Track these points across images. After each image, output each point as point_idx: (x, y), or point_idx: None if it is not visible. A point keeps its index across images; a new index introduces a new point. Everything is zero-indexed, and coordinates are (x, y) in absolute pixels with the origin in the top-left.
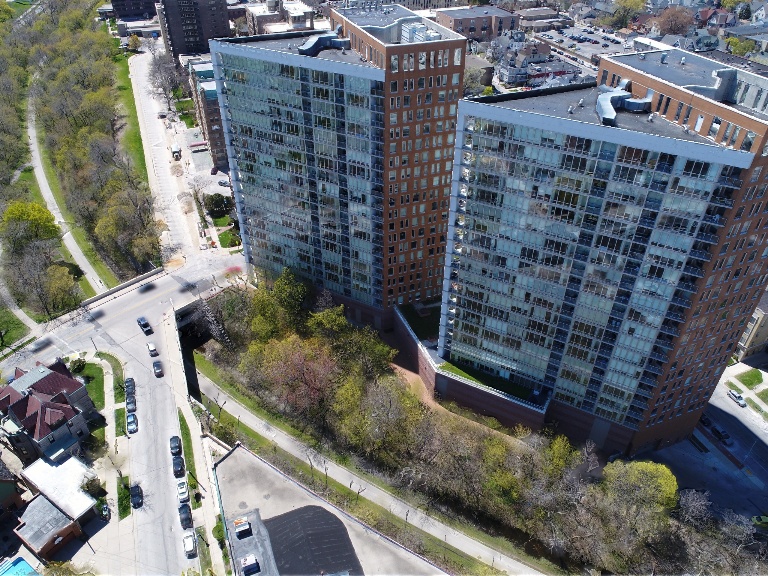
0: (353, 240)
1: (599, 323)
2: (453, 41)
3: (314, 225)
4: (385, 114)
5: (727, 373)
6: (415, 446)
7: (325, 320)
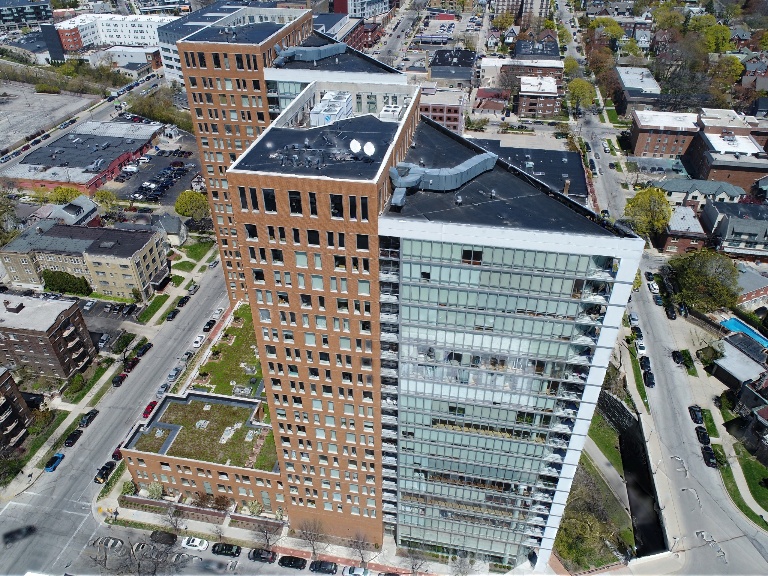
0: None
1: None
2: (332, 83)
3: None
4: None
5: (190, 275)
6: None
7: None
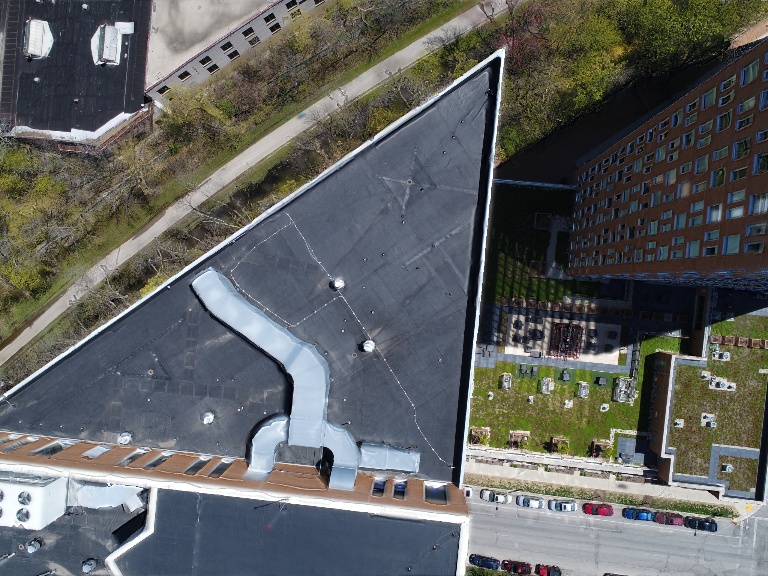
0: None
1: None
2: None
3: None
4: (762, 44)
5: None
6: None
7: None
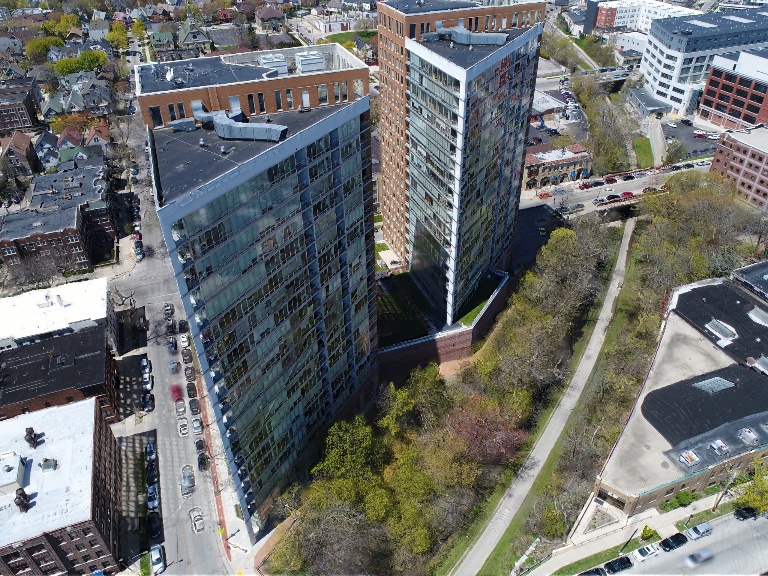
0: (354, 320)
1: None
2: None
3: (320, 351)
4: None
5: None
6: (507, 386)
7: (404, 408)
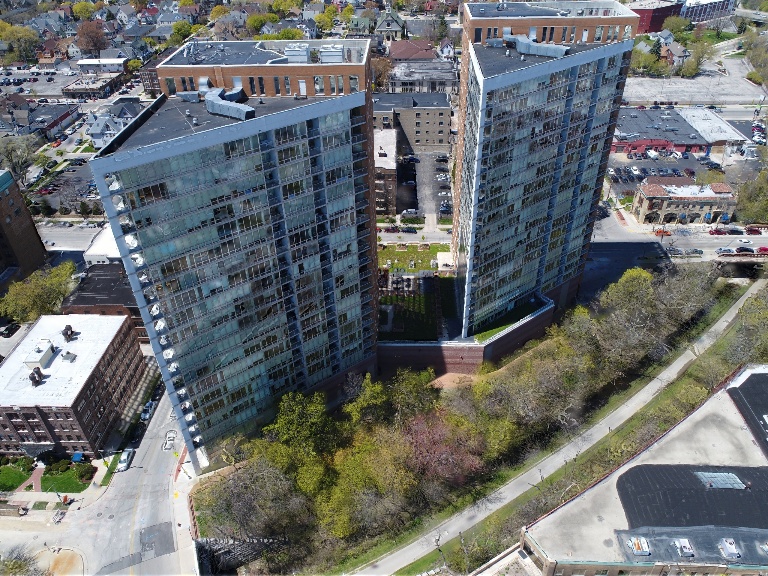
0: (340, 304)
1: (566, 210)
2: None
3: (291, 323)
4: (367, 140)
5: None
6: None
7: (371, 400)
